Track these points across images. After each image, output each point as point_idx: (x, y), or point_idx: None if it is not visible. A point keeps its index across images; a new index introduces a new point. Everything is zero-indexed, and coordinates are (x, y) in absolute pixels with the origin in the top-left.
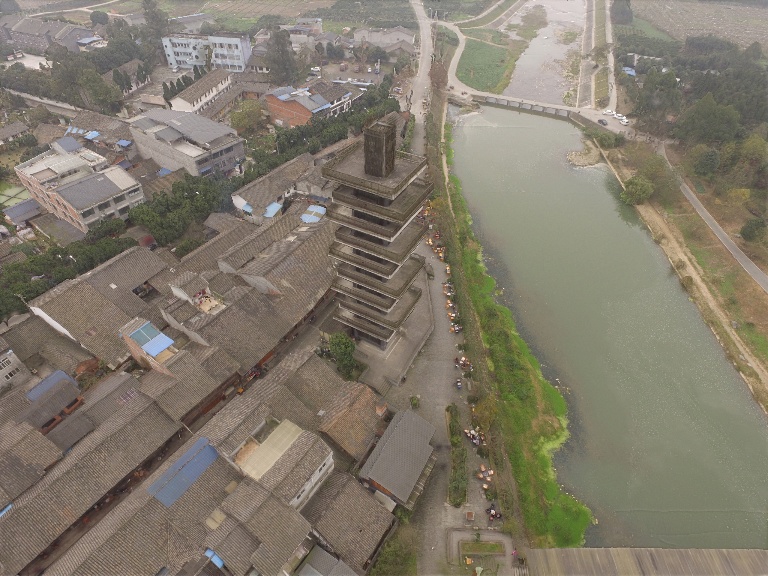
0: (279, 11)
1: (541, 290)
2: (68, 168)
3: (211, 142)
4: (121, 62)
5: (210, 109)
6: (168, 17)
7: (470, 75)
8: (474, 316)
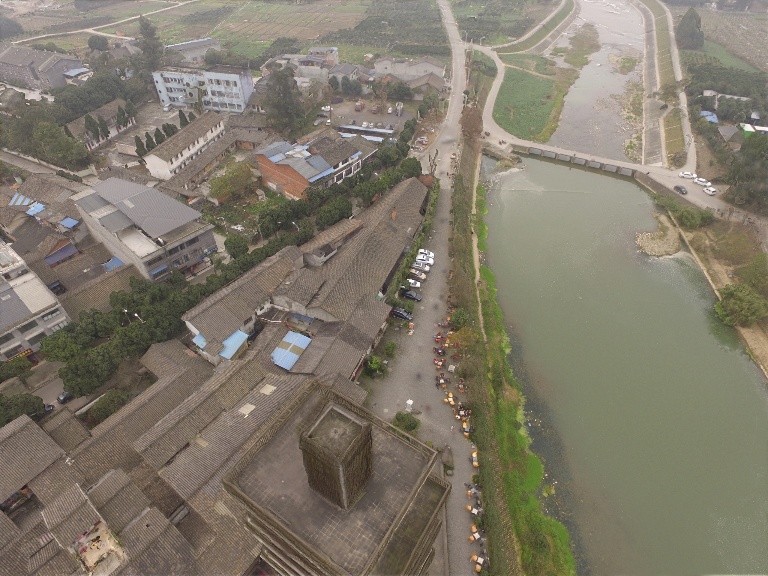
0: (297, 32)
1: (612, 489)
2: None
3: (170, 231)
4: (100, 103)
5: (191, 167)
6: (162, 47)
7: (510, 116)
8: (512, 543)
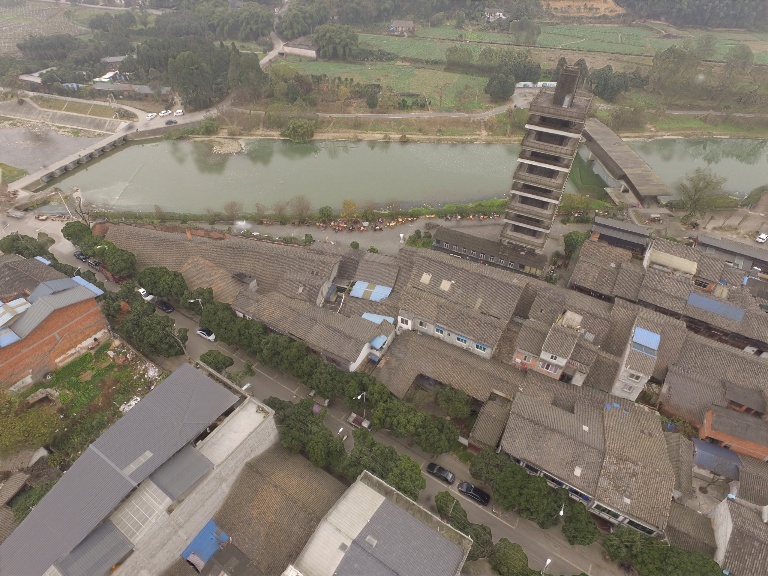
0: None
1: (423, 190)
2: None
3: None
4: None
5: None
6: None
7: None
8: None
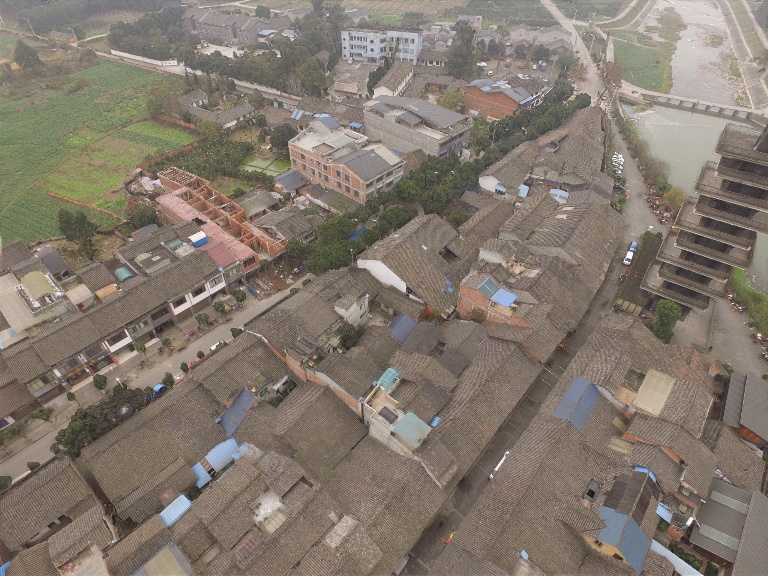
0: (416, 9)
1: None
2: (341, 144)
3: None
4: (313, 53)
5: None
6: None
7: (631, 75)
8: None
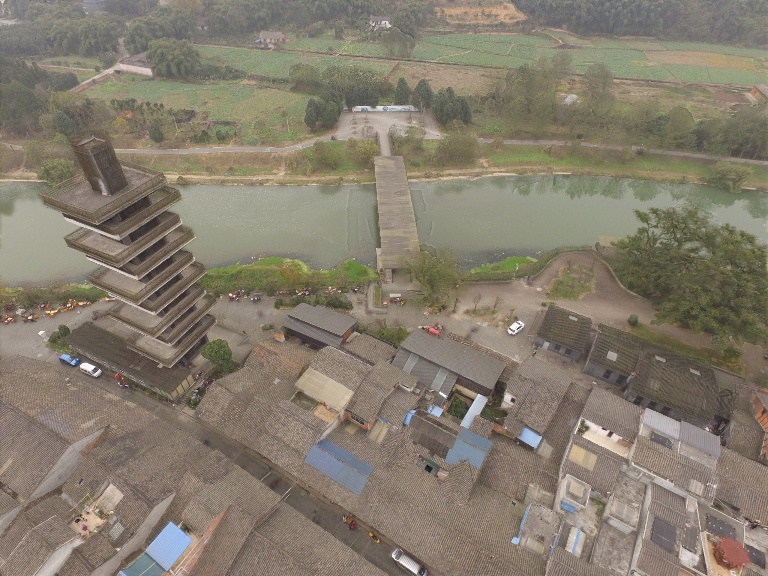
0: None
1: None
2: None
3: None
4: None
5: None
6: None
7: None
8: None
